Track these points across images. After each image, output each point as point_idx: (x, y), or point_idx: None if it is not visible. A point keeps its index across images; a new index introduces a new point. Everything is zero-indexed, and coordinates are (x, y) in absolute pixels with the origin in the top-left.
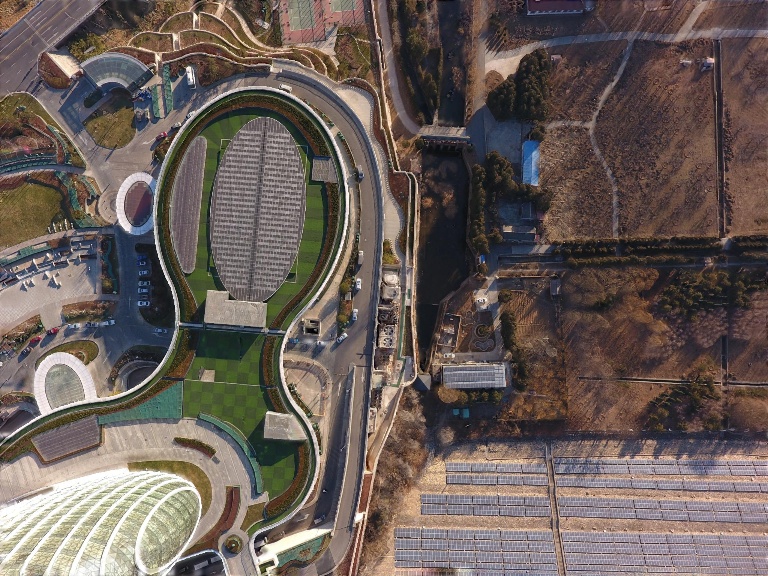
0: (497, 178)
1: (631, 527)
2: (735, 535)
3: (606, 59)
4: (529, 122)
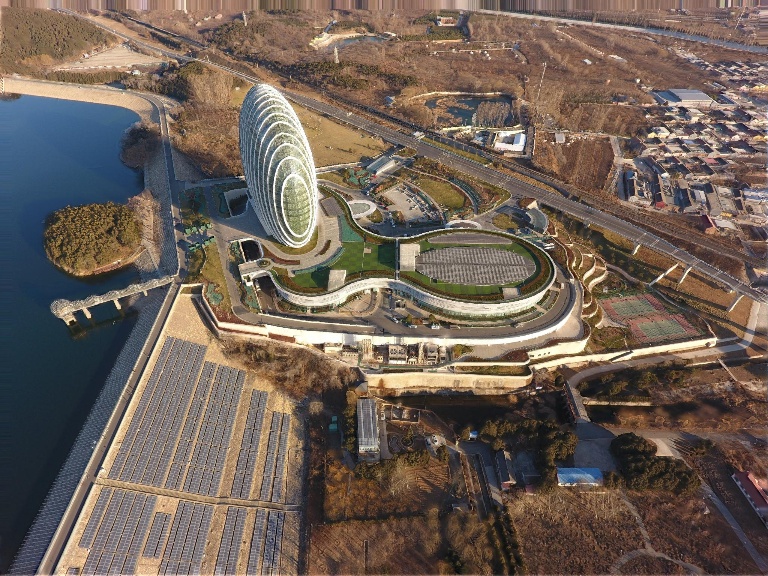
0: (551, 435)
1: None
2: None
3: (737, 569)
4: (622, 479)
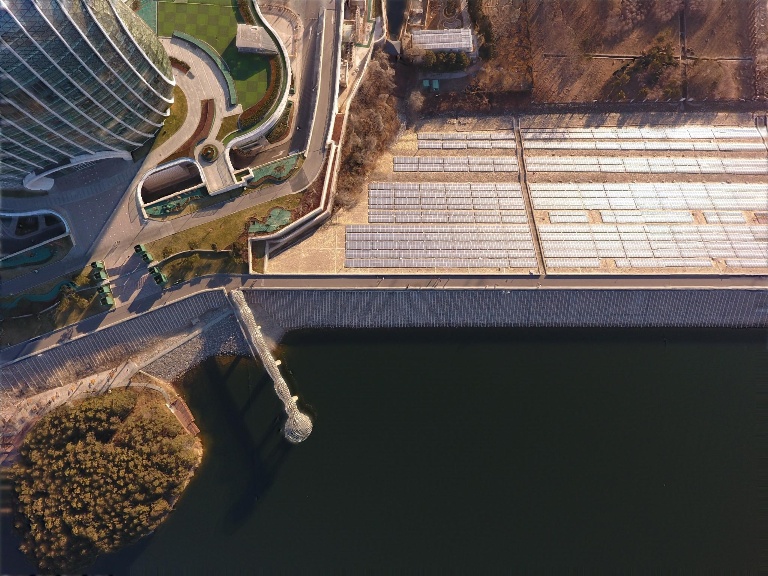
0: None
1: (595, 179)
2: (695, 184)
3: None
4: None
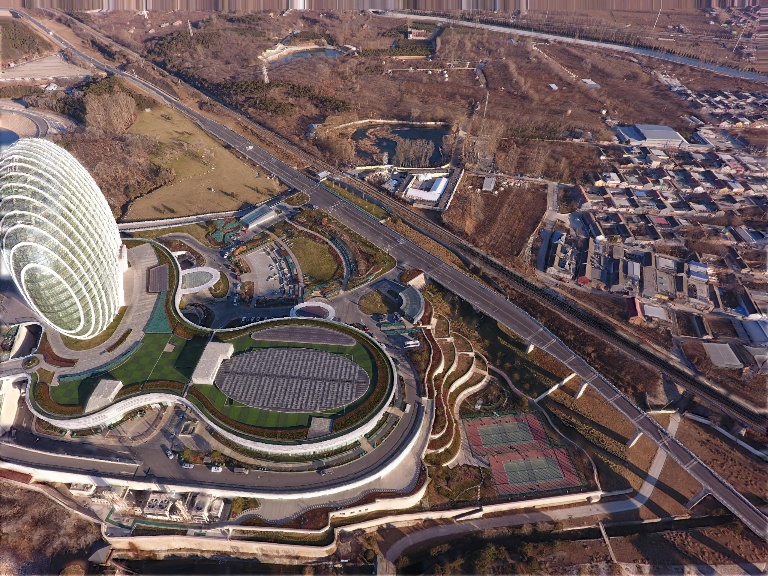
0: None
1: None
2: None
3: None
4: None
